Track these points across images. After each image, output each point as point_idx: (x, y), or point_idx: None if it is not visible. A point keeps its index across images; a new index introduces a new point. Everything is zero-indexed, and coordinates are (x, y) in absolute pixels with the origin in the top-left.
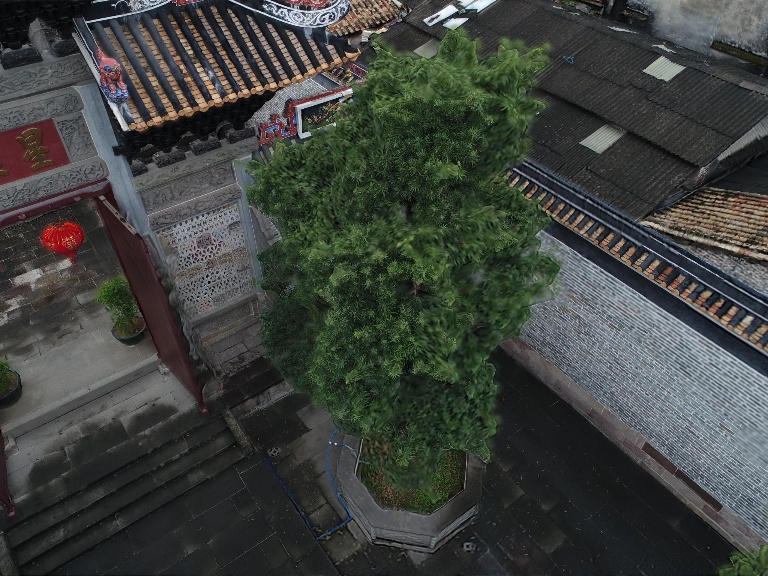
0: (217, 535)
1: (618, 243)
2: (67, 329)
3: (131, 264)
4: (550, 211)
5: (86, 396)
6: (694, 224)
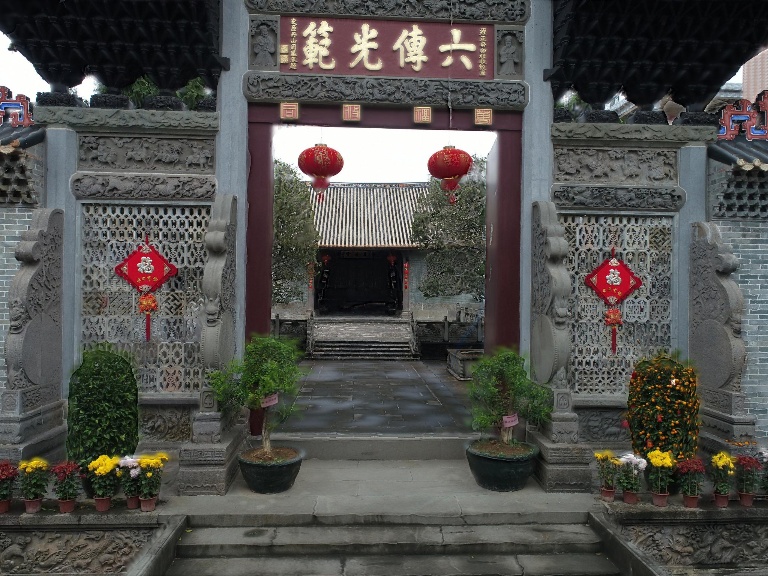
0: (325, 427)
1: None
2: (375, 572)
3: None
4: None
5: None
6: None
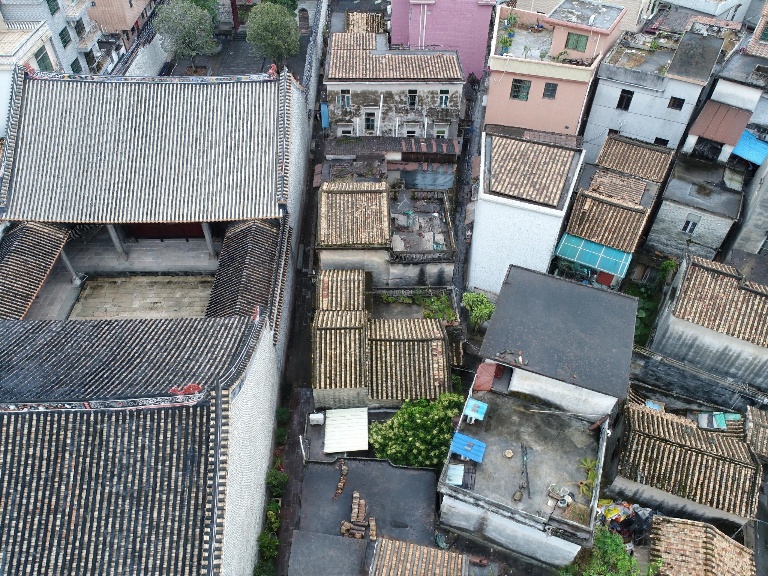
0: None
1: None
2: None
3: None
4: None
5: None
6: None
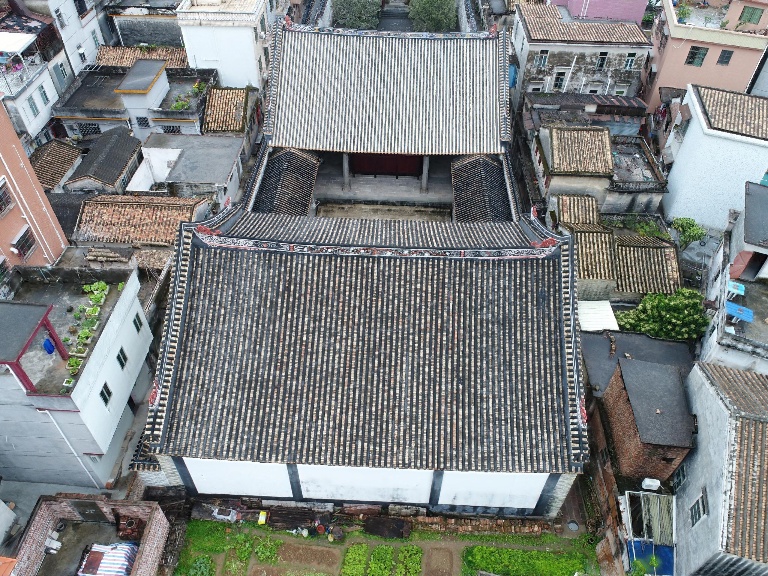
0: None
1: None
2: None
3: None
4: None
5: (397, 6)
6: None
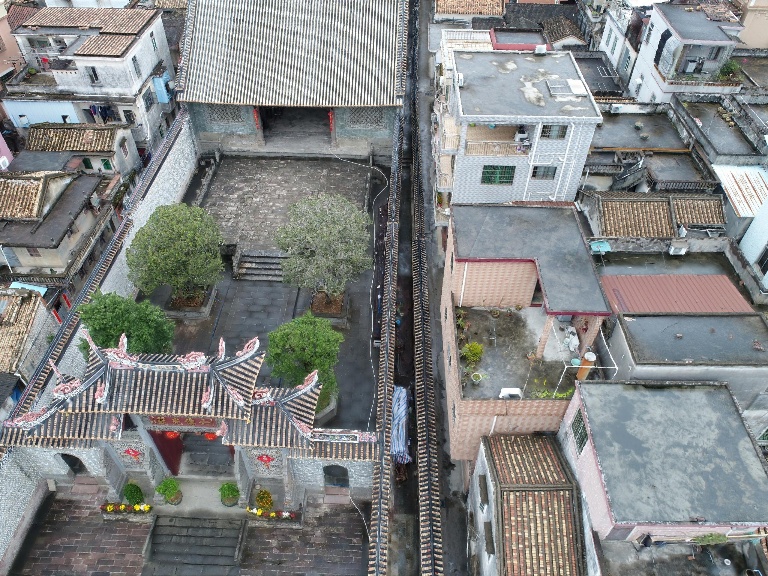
0: None
1: (62, 340)
2: (193, 534)
3: (163, 437)
4: (54, 362)
5: None
6: (7, 355)
